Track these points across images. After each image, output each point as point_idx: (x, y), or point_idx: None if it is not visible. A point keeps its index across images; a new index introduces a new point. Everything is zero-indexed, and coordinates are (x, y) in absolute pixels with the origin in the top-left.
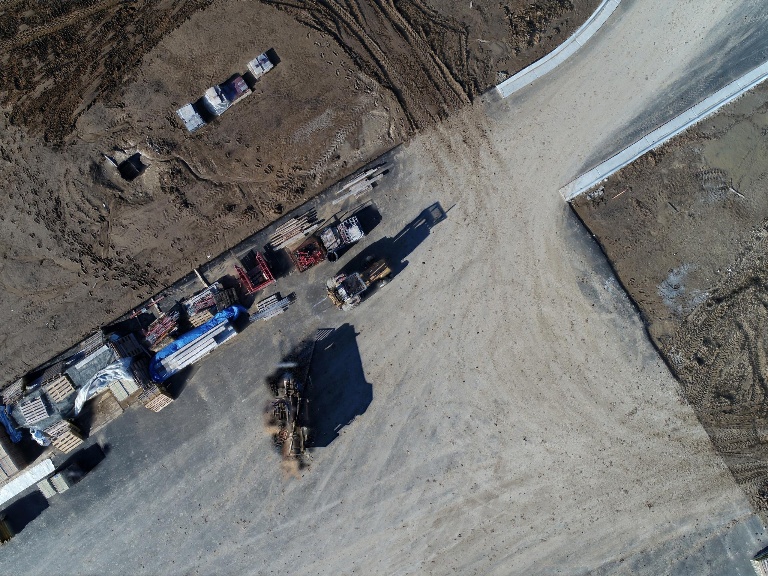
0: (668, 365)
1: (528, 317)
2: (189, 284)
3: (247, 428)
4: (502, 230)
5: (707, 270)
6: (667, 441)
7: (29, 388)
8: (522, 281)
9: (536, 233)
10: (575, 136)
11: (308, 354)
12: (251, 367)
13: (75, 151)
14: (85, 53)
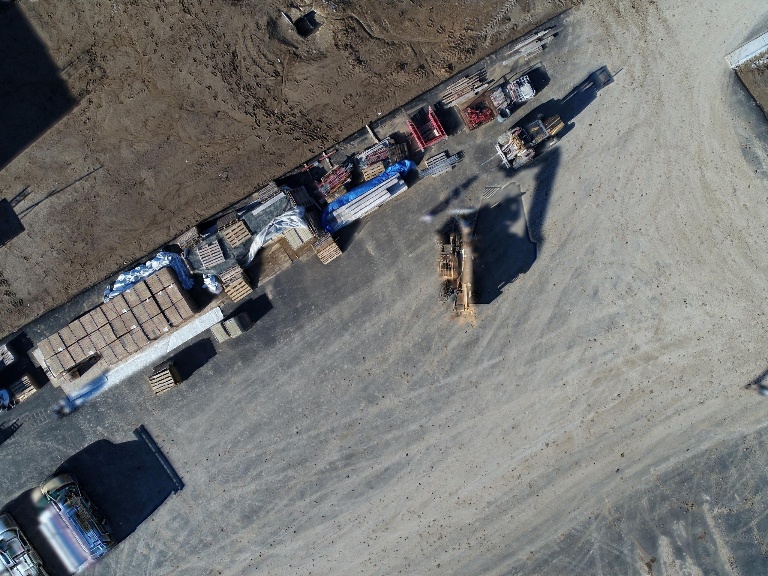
0: None
1: (691, 181)
2: (360, 140)
3: (412, 283)
4: (668, 95)
5: None
6: None
7: (202, 236)
8: (686, 146)
9: (701, 99)
10: (742, 4)
11: (474, 212)
12: (418, 223)
13: (253, 6)
14: None
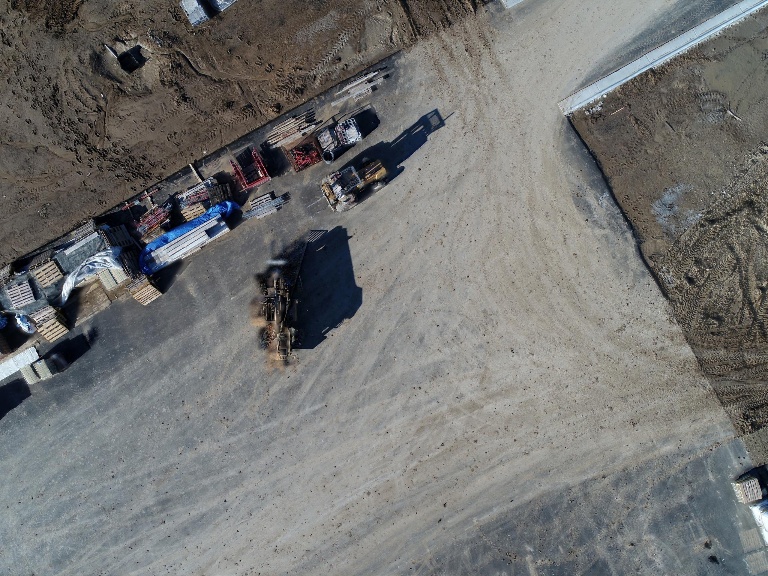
0: (658, 284)
1: (521, 229)
2: (183, 178)
3: (235, 326)
4: (499, 141)
5: (701, 191)
6: (654, 360)
7: (17, 274)
8: (517, 192)
9: (533, 145)
10: (576, 50)
11: (299, 255)
12: (242, 265)
13: (76, 39)
14: None
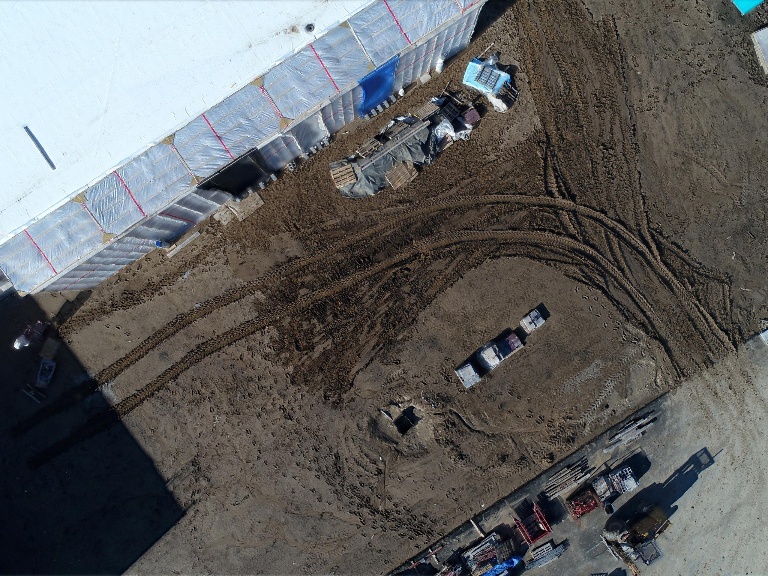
0: None
1: None
2: (465, 534)
3: None
4: None
5: None
6: None
7: None
8: None
9: None
10: None
11: None
12: None
13: (353, 408)
14: (362, 313)
